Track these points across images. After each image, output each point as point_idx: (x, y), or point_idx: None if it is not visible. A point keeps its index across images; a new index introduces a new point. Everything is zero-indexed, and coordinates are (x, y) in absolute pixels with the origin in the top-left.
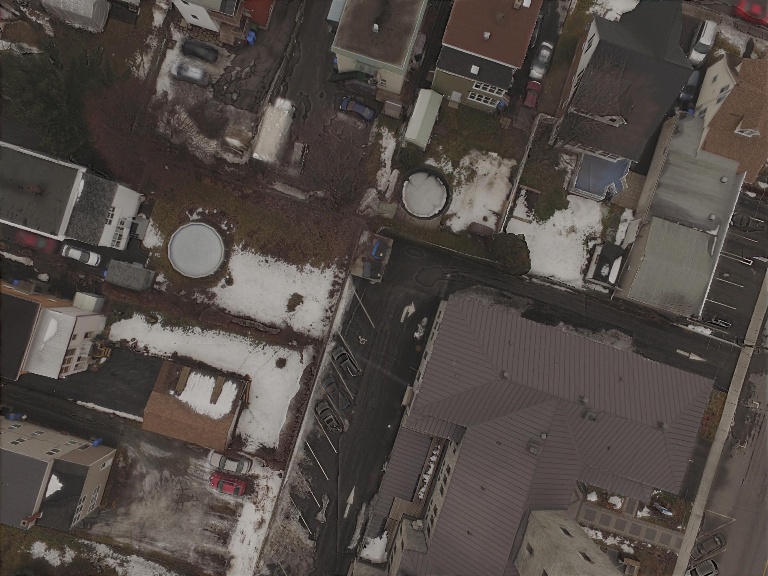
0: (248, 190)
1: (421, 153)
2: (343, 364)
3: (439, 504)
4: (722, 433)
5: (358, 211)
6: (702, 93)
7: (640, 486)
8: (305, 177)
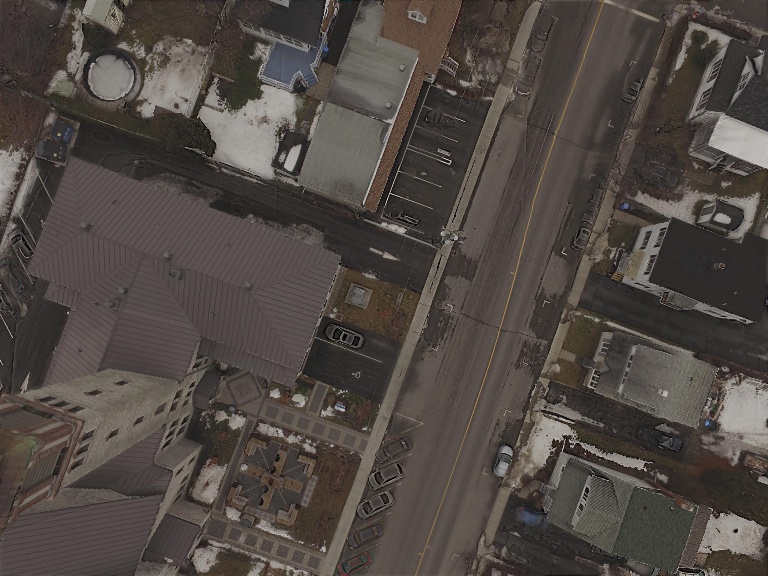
0: None
1: (113, 36)
2: (15, 245)
3: None
4: (413, 335)
5: (46, 93)
6: None
7: (281, 369)
8: None
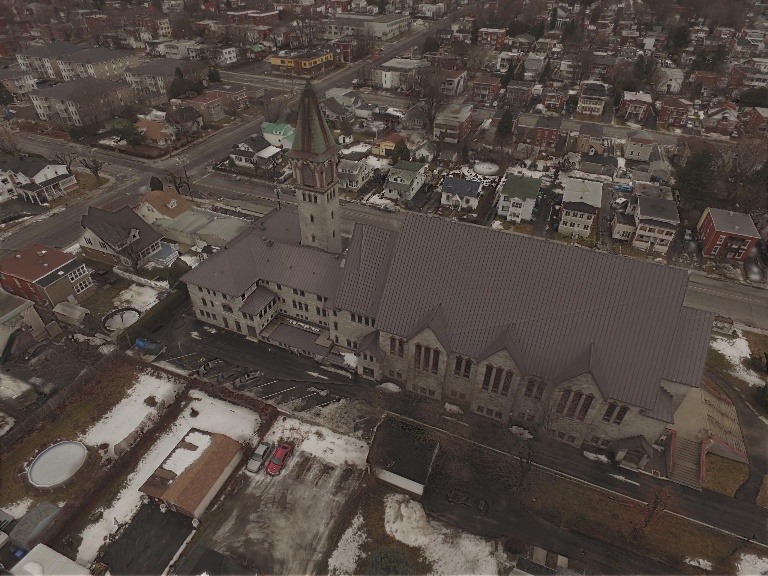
0: (38, 425)
1: None
2: (210, 366)
3: (311, 305)
4: None
5: None
6: (149, 223)
7: None
8: (59, 385)
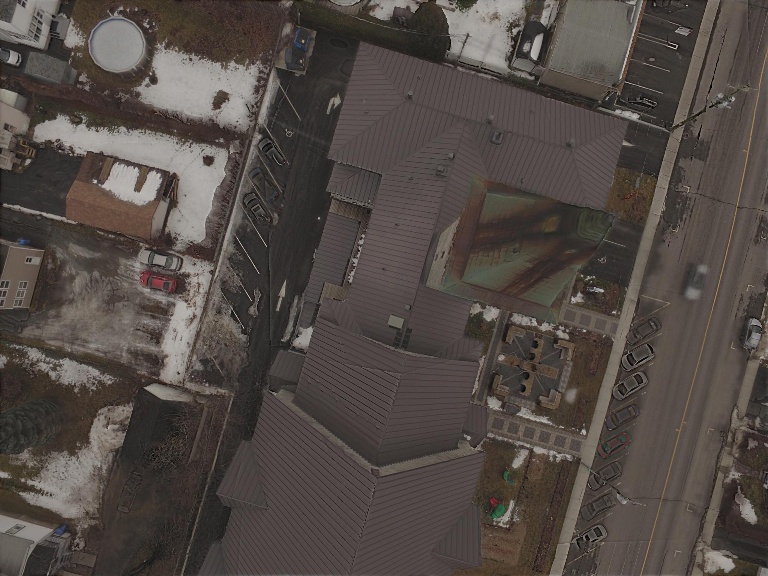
0: None
1: None
2: (268, 152)
3: None
4: (654, 217)
5: (280, 4)
6: None
7: None
8: None
